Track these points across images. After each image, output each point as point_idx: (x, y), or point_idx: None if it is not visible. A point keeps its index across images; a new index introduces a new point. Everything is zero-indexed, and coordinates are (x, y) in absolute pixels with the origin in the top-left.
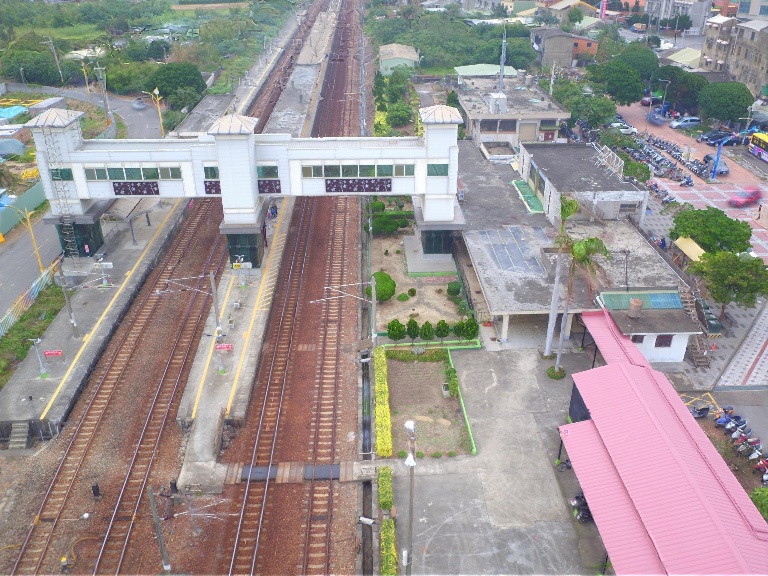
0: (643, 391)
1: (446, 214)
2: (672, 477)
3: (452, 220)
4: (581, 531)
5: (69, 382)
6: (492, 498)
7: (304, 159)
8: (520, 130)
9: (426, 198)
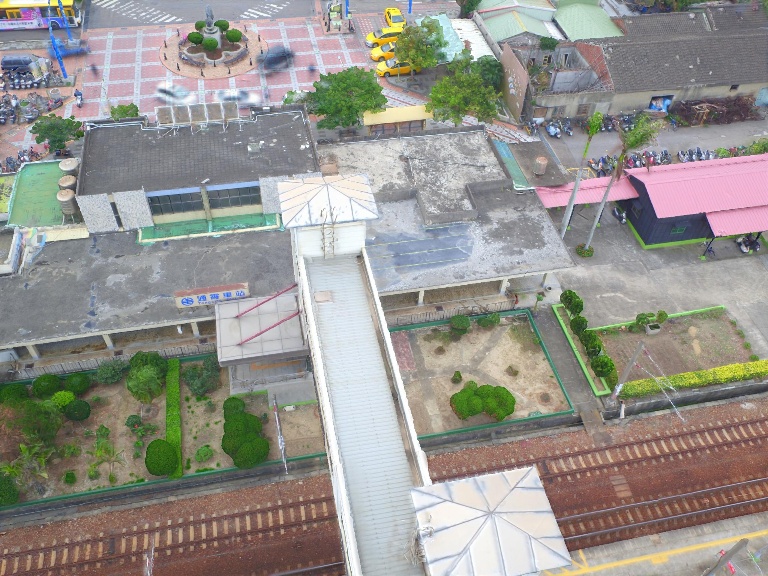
0: (677, 177)
1: None
2: (763, 178)
3: None
4: (764, 251)
5: None
6: (765, 297)
7: None
8: None
9: None
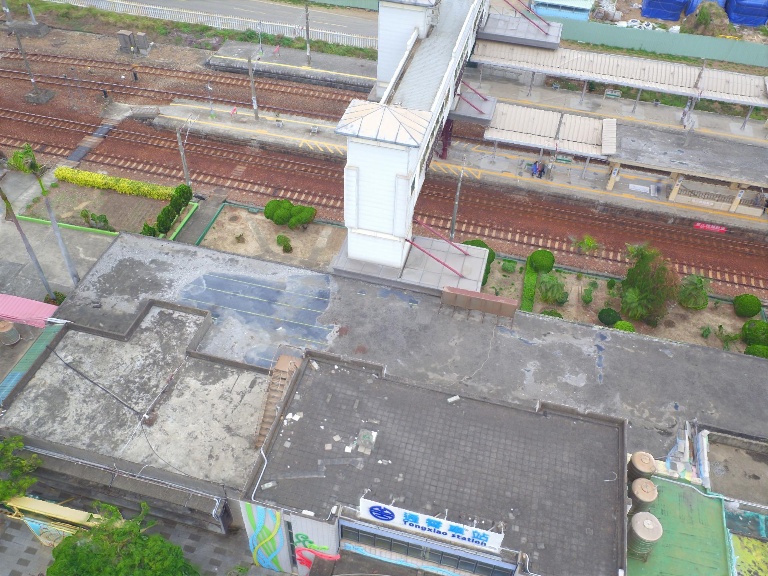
0: None
1: None
2: None
3: (349, 256)
4: None
5: None
6: None
7: None
8: None
9: None
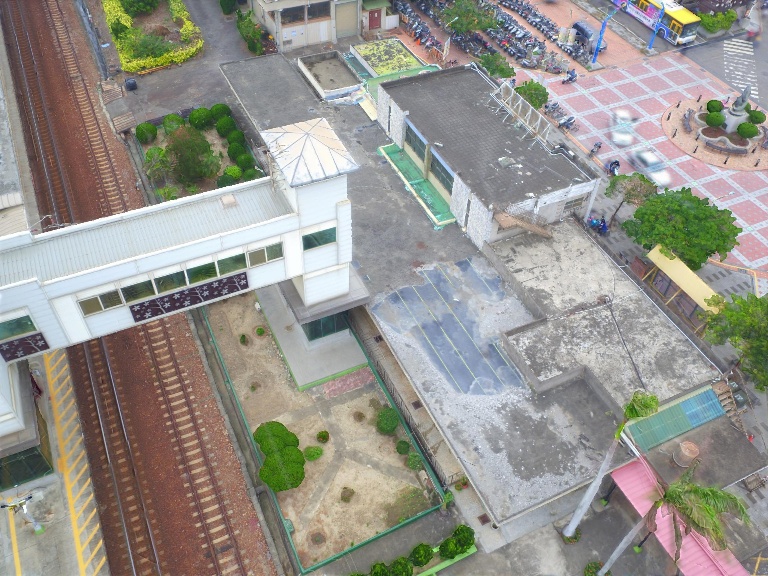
0: None
1: (337, 288)
2: None
3: (347, 292)
4: None
5: None
6: None
7: (79, 290)
8: (336, 13)
9: (305, 278)
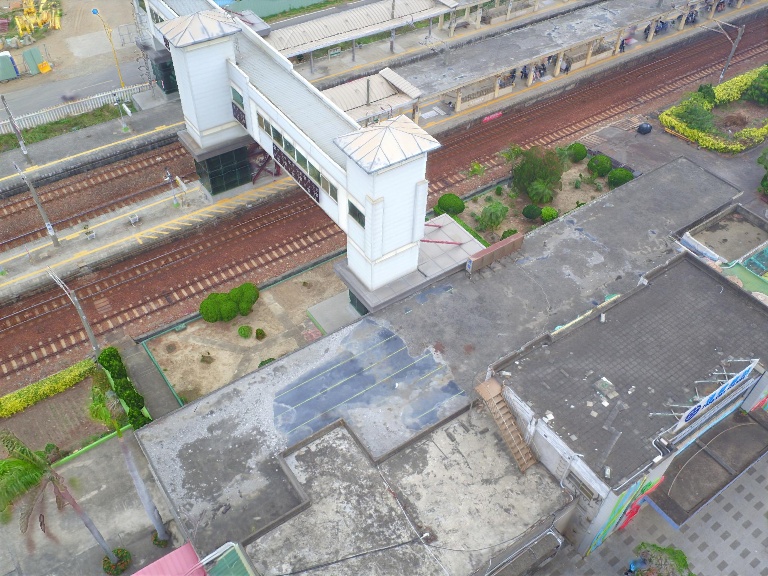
0: None
1: (366, 277)
2: None
3: (371, 289)
4: None
5: None
6: None
7: (259, 105)
8: None
9: (349, 240)
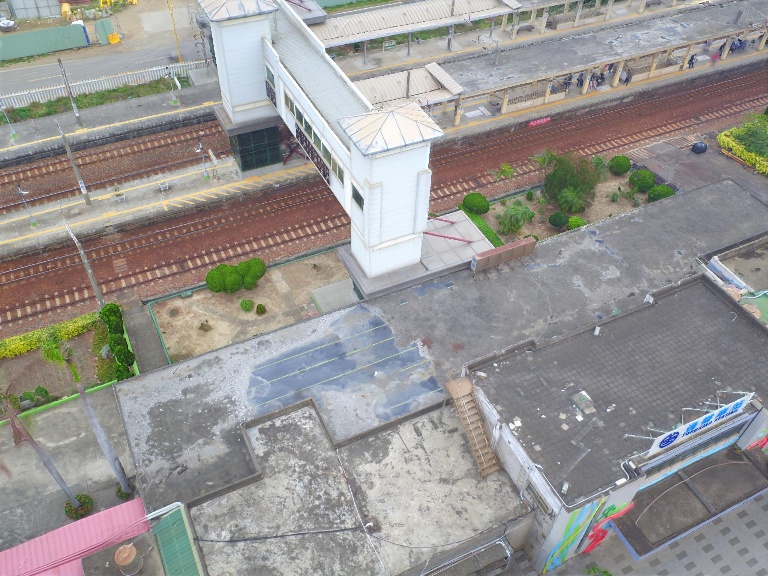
0: None
1: (365, 263)
2: None
3: (368, 276)
4: None
5: (8, 151)
6: None
7: None
8: None
9: (352, 224)
